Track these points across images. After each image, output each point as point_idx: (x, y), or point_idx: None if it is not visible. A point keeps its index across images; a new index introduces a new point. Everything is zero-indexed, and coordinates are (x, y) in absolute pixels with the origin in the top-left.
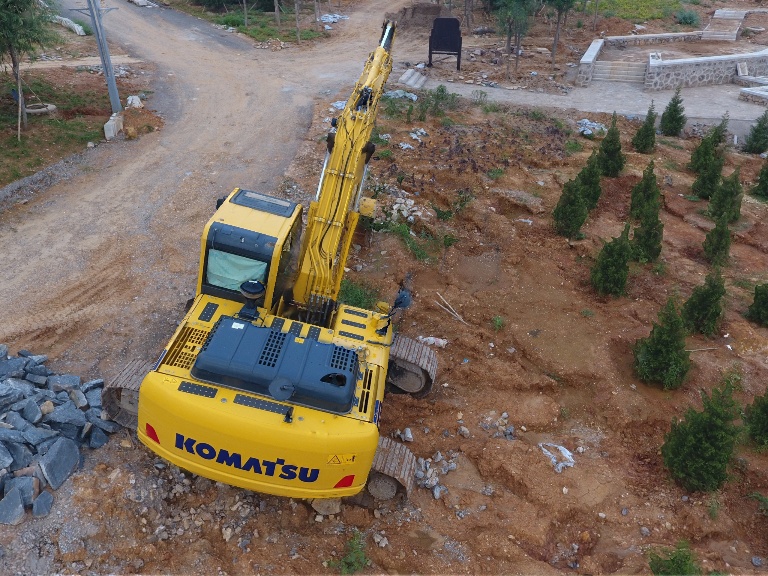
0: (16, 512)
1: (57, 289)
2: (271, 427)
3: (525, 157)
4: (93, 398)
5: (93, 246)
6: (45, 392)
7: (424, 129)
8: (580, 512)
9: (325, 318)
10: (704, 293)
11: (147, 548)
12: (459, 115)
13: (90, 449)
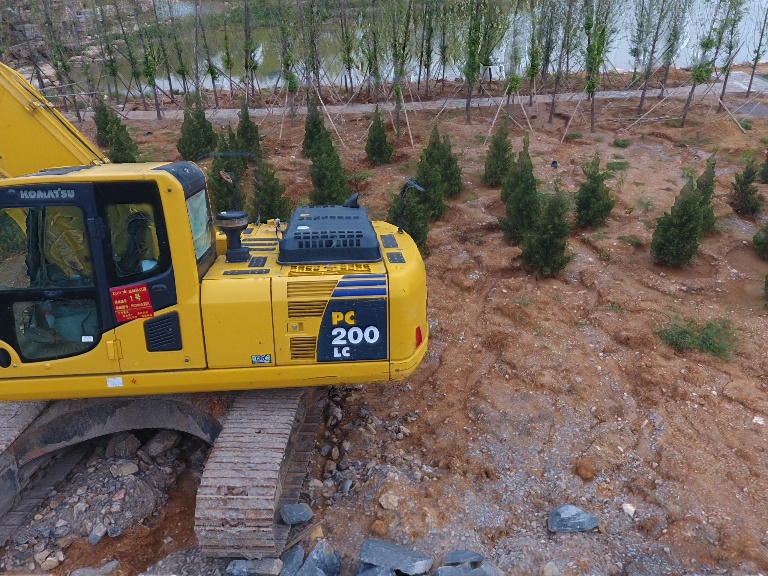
0: (492, 573)
1: None
2: None
3: None
4: None
5: None
6: None
7: None
8: None
9: None
10: None
11: (458, 464)
12: None
13: (340, 571)
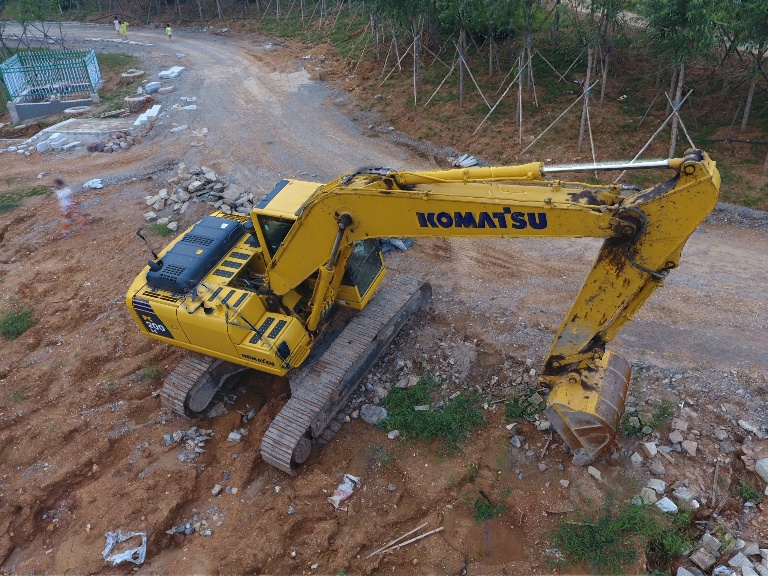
0: None
1: (510, 248)
2: None
3: None
4: None
5: (591, 257)
6: None
7: None
8: None
9: None
10: None
11: None
12: None
13: None
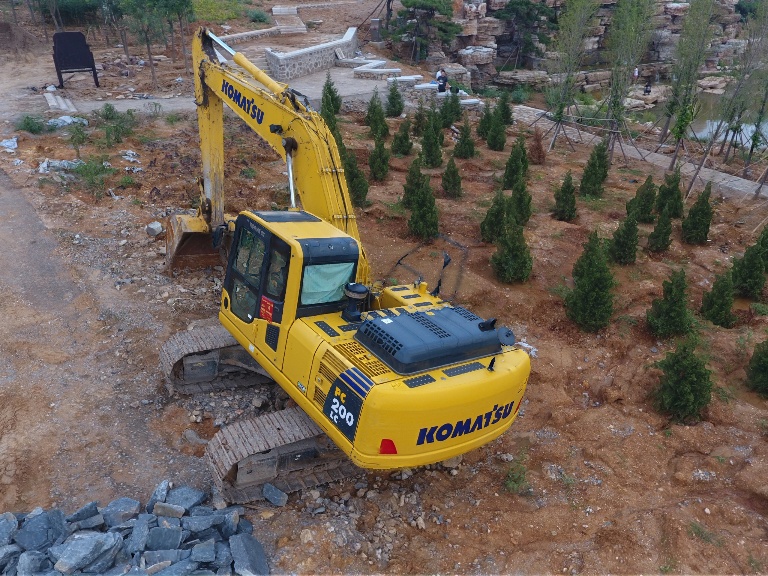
0: None
1: None
2: (488, 380)
3: (251, 154)
4: (180, 501)
5: None
6: (129, 524)
7: (131, 150)
8: (570, 373)
9: (370, 307)
10: (496, 211)
11: (395, 570)
12: (147, 130)
13: None
